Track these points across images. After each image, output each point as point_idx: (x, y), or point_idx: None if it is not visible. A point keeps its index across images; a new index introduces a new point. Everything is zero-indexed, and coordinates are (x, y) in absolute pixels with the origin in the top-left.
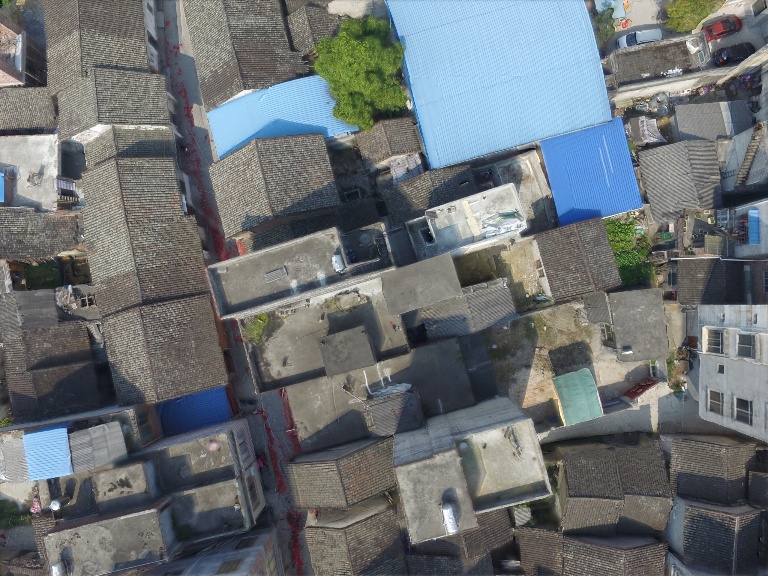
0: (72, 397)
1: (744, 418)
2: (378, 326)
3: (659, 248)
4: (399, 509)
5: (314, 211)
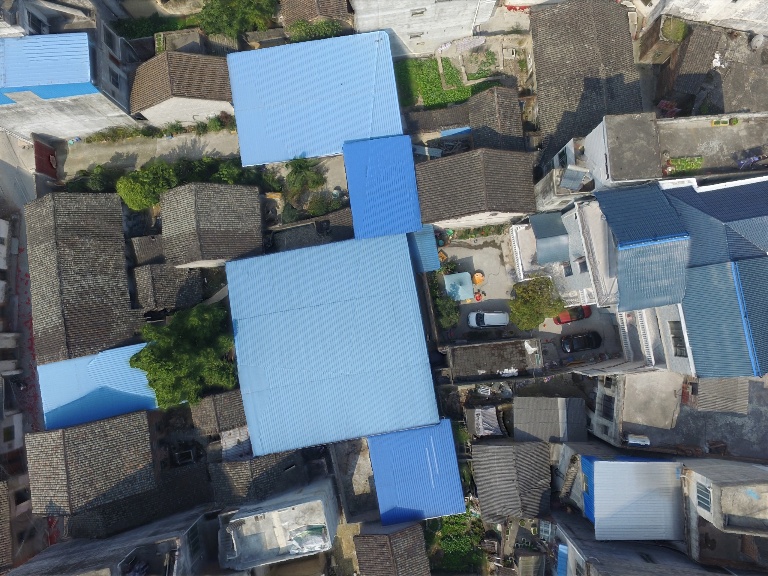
0: None
1: None
2: None
3: (492, 535)
4: None
5: (122, 500)
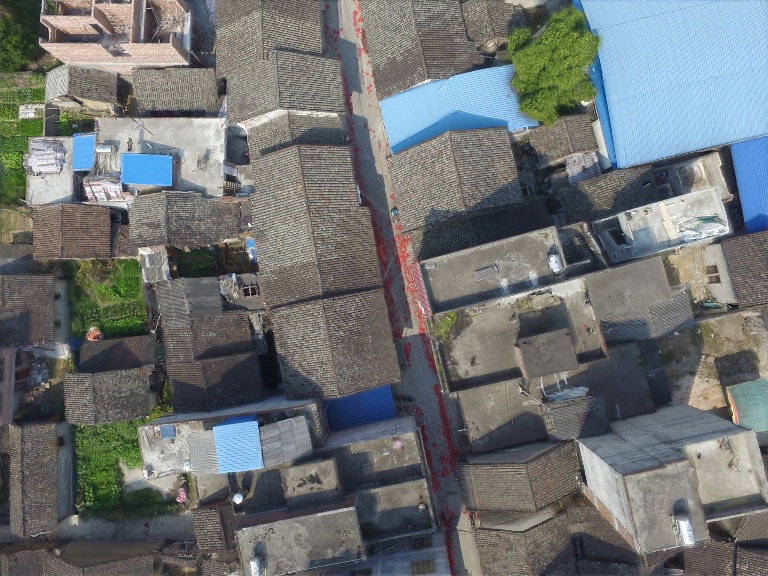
0: (238, 388)
1: None
2: (571, 328)
3: None
4: (570, 514)
5: (501, 207)
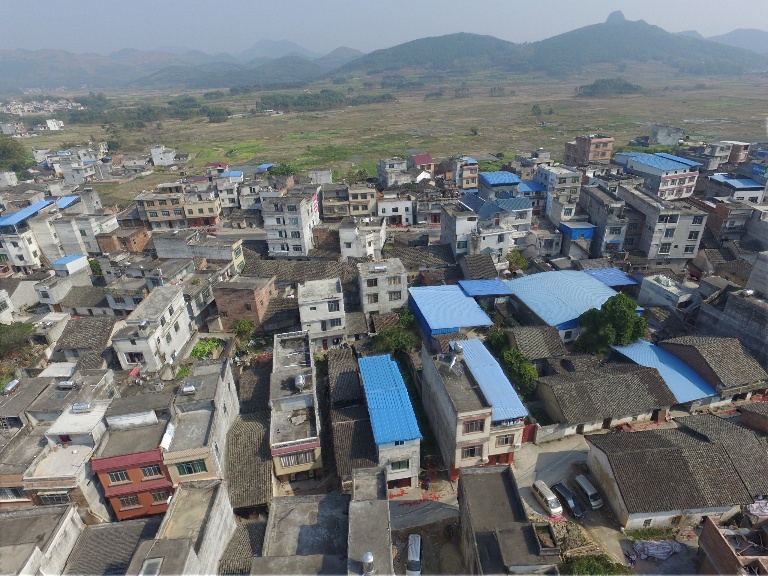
0: None
1: (696, 235)
2: None
3: None
4: None
5: None
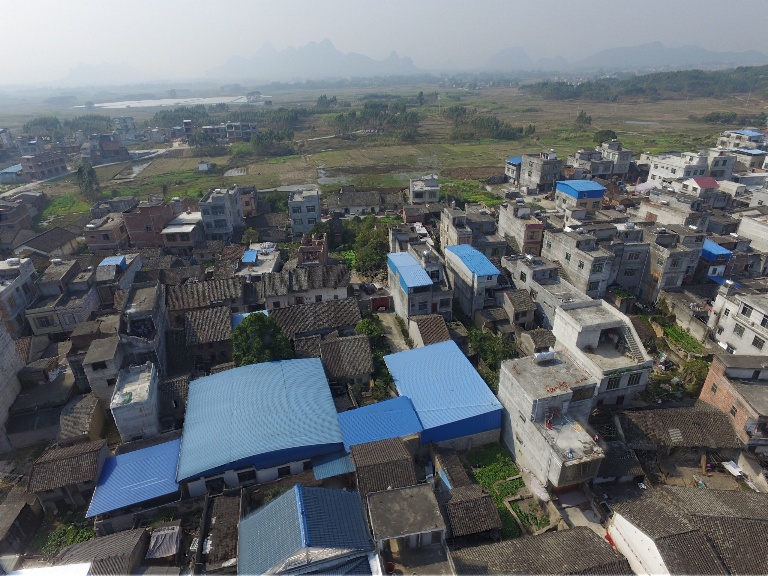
0: (142, 281)
1: None
2: None
3: None
4: None
5: (184, 332)
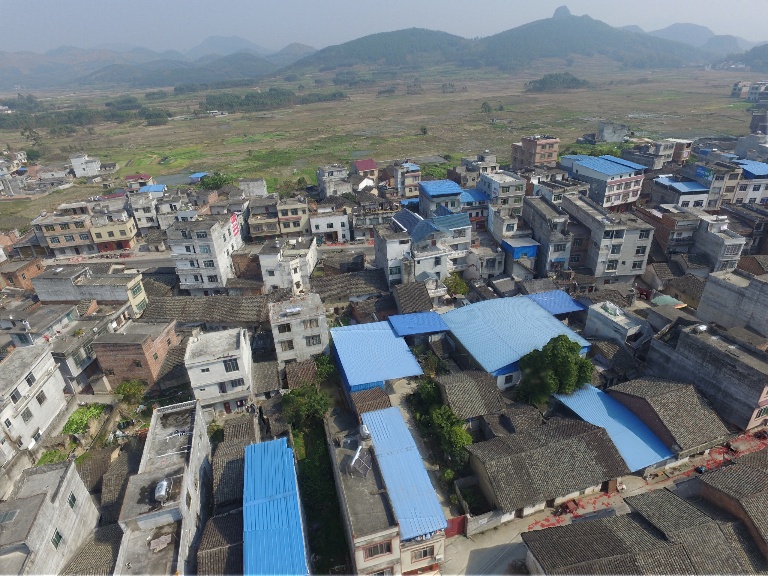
0: None
1: (643, 250)
2: None
3: None
4: None
5: None
